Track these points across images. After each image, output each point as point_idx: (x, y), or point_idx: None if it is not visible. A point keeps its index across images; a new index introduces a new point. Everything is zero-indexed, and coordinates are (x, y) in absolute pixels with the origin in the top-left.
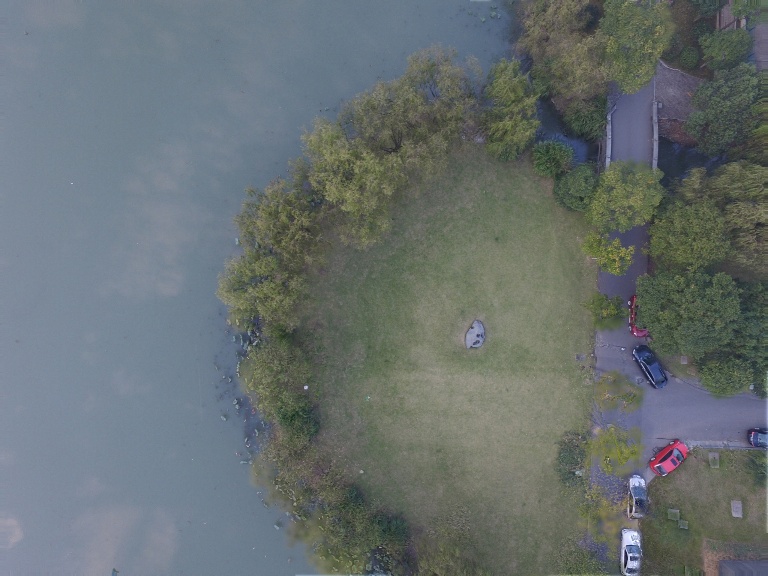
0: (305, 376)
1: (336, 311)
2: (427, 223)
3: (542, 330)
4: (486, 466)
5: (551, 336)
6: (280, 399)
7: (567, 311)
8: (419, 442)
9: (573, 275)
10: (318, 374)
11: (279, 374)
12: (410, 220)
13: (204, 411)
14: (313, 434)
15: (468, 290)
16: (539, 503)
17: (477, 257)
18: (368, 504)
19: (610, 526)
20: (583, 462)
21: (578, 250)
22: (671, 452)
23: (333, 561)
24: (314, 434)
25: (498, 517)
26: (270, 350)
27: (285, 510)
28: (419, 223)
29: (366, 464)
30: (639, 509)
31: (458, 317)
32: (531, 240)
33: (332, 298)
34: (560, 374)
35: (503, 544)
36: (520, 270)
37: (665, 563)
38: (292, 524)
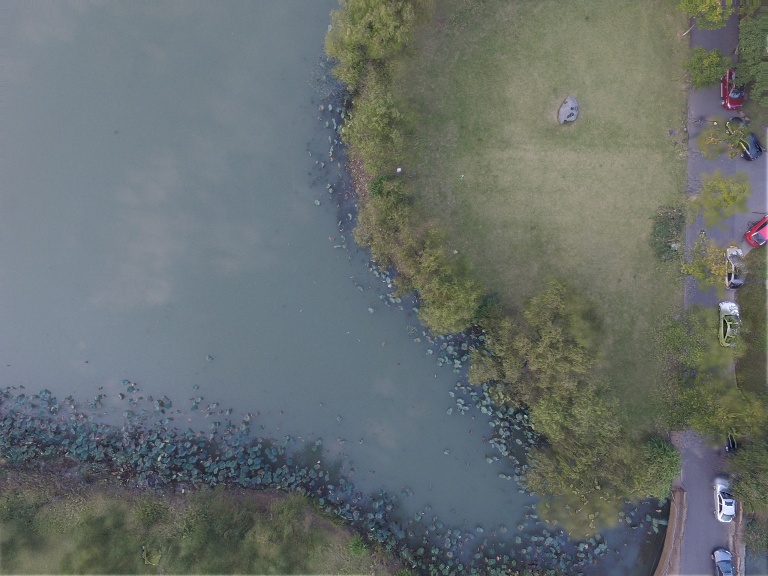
0: (398, 159)
1: (428, 94)
2: (517, 4)
3: (634, 106)
4: (581, 243)
5: (643, 112)
6: (390, 139)
7: (658, 88)
8: (513, 219)
9: (664, 52)
10: (411, 155)
11: (391, 108)
12: (500, 2)
13: (297, 198)
14: (407, 216)
15: (560, 68)
16: (634, 279)
17: (568, 36)
18: (463, 284)
19: (707, 299)
20: (678, 236)
21: (668, 28)
22: (767, 221)
23: (428, 343)
24: (408, 216)
25: (593, 294)
26: (362, 135)
27: (379, 294)
28: (509, 5)
29: (460, 244)
30: (738, 276)
31: (550, 95)
32: (621, 19)
33: (424, 82)
34: (653, 150)
35: (599, 321)
36: (611, 48)
37: (765, 332)
38: (386, 308)
